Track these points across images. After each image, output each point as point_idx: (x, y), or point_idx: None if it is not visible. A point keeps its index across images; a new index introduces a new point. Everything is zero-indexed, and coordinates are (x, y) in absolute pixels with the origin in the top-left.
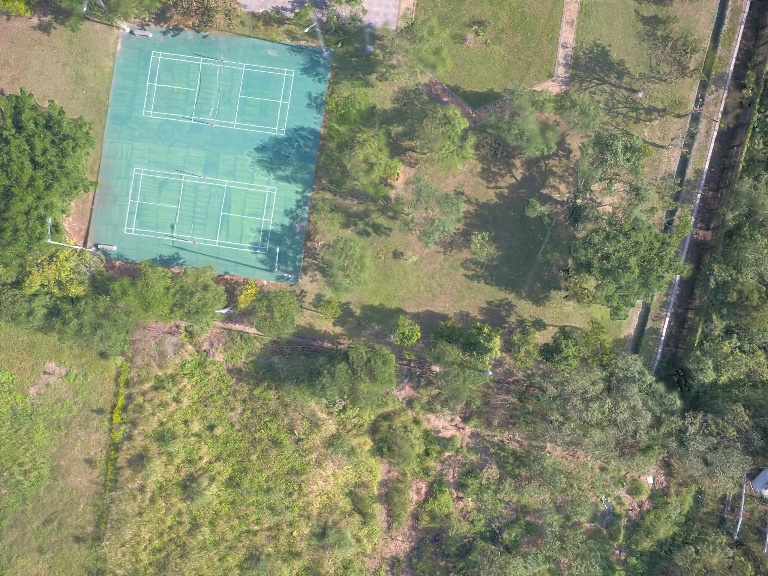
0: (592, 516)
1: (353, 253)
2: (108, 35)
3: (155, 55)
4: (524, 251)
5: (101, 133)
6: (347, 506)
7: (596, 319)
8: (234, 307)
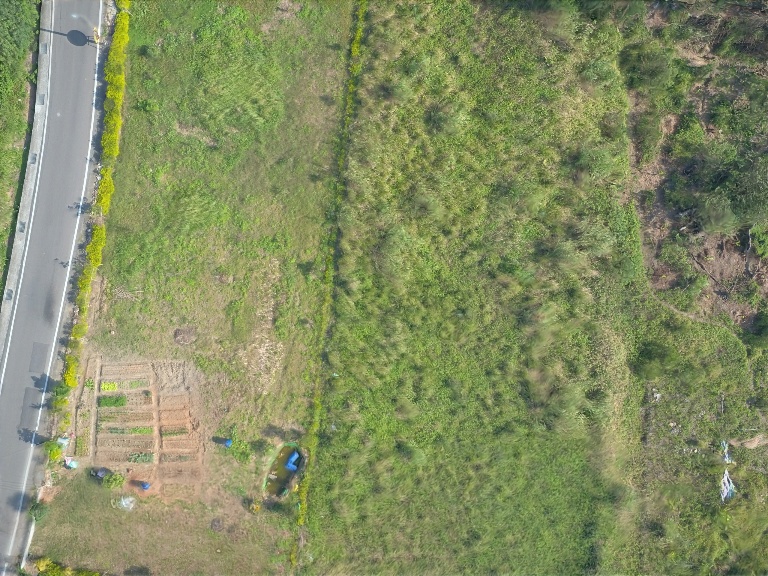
0: None
1: None
2: None
3: None
4: None
5: None
6: (597, 136)
7: None
8: None
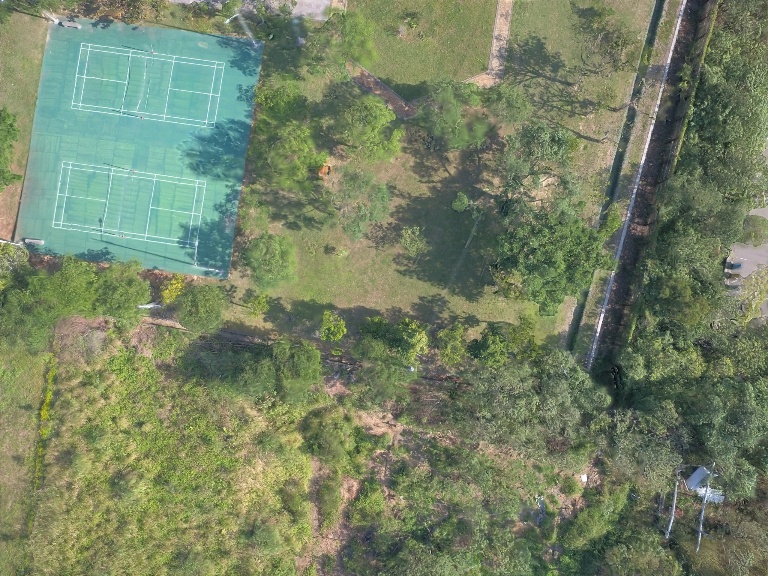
0: (525, 514)
1: (275, 247)
2: (37, 27)
3: (84, 47)
4: (457, 246)
5: (29, 126)
6: (277, 504)
7: (530, 315)
8: (161, 302)
